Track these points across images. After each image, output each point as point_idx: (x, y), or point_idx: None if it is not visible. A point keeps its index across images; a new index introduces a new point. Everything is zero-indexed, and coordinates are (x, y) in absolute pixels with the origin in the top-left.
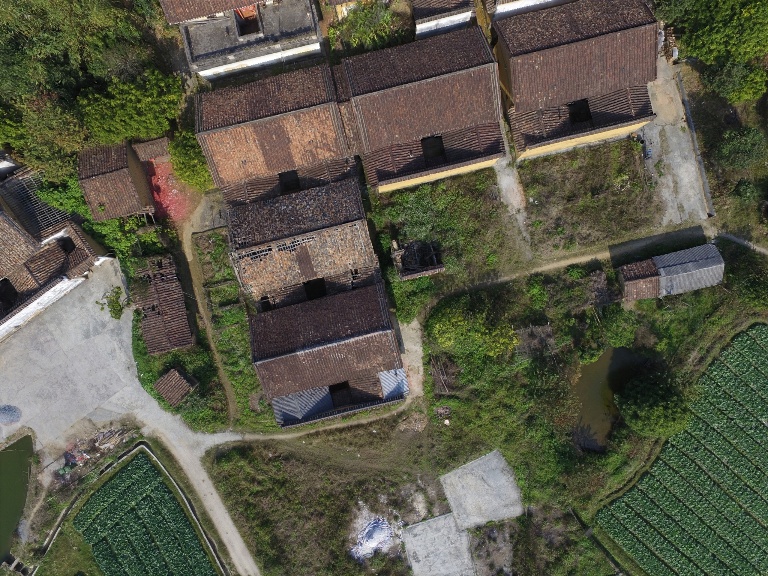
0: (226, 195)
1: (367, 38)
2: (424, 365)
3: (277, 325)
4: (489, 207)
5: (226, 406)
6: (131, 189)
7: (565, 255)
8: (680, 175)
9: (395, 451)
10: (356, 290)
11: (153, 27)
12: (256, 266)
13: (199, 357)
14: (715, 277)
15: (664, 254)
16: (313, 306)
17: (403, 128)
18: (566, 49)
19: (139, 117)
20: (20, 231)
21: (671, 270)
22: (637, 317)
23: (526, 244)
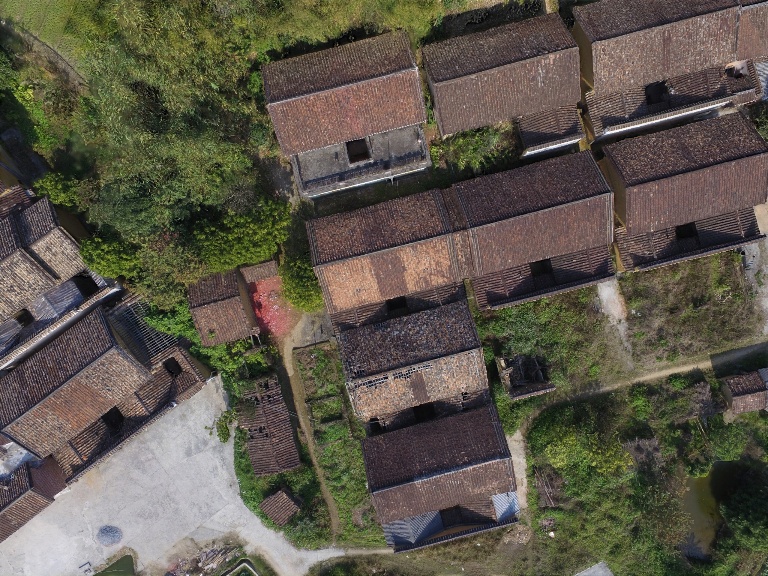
0: (334, 317)
1: (476, 162)
2: (528, 477)
3: (391, 450)
4: (593, 320)
5: (329, 522)
6: (242, 316)
7: (667, 365)
8: None
9: (500, 564)
10: (468, 412)
11: None
12: (371, 393)
13: (304, 476)
14: None
15: None
16: (425, 430)
17: (516, 254)
18: (681, 178)
19: (255, 249)
20: (134, 363)
21: None
22: None
23: (627, 354)
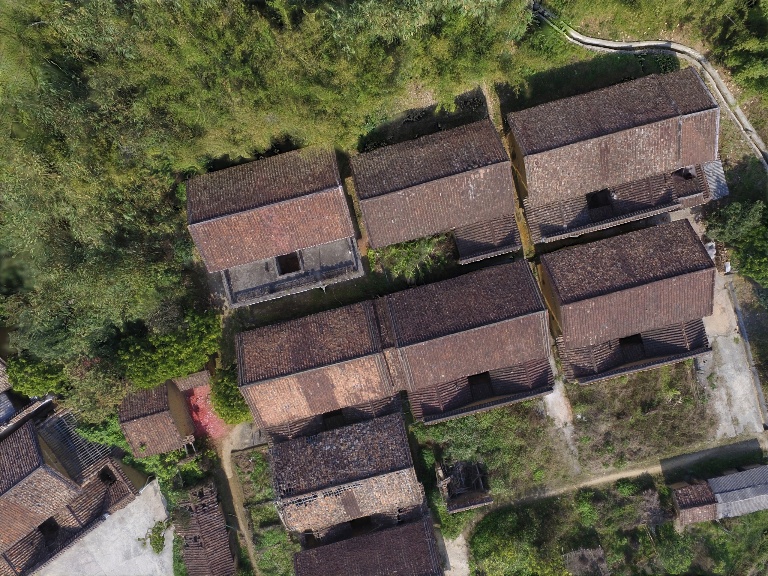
0: (267, 426)
1: (410, 271)
2: None
3: (323, 566)
4: (536, 426)
5: None
6: (172, 429)
7: (615, 469)
8: (734, 388)
9: None
10: (403, 527)
11: None
12: (301, 511)
13: None
14: None
15: (719, 474)
16: (359, 544)
17: (449, 369)
18: (619, 294)
19: (181, 367)
20: (62, 480)
21: (728, 496)
22: (691, 531)
23: (574, 458)
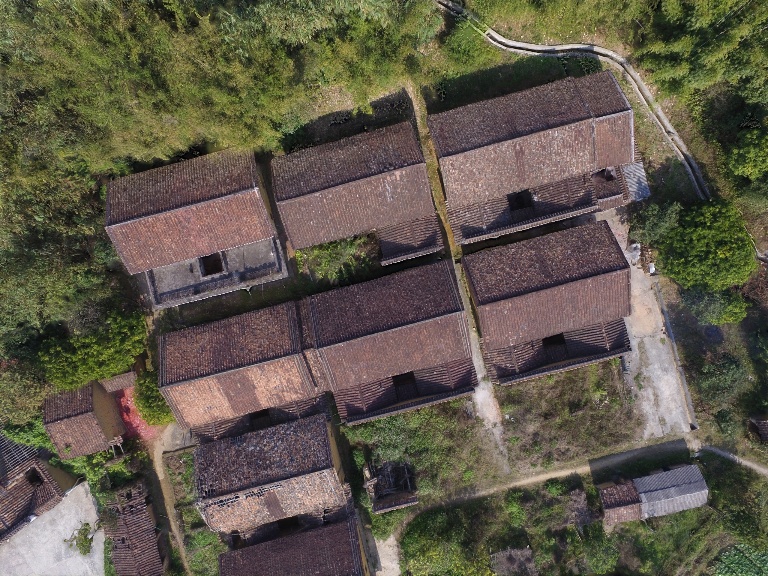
0: (194, 428)
1: (333, 272)
2: None
3: (247, 567)
4: (464, 427)
5: None
6: (97, 430)
7: None
8: (661, 388)
9: None
10: (327, 527)
11: (118, 255)
12: (224, 512)
13: None
14: (699, 501)
15: (646, 473)
16: (284, 545)
17: (371, 370)
18: (535, 295)
19: (102, 368)
20: None
21: (652, 496)
22: (620, 531)
23: (503, 458)
